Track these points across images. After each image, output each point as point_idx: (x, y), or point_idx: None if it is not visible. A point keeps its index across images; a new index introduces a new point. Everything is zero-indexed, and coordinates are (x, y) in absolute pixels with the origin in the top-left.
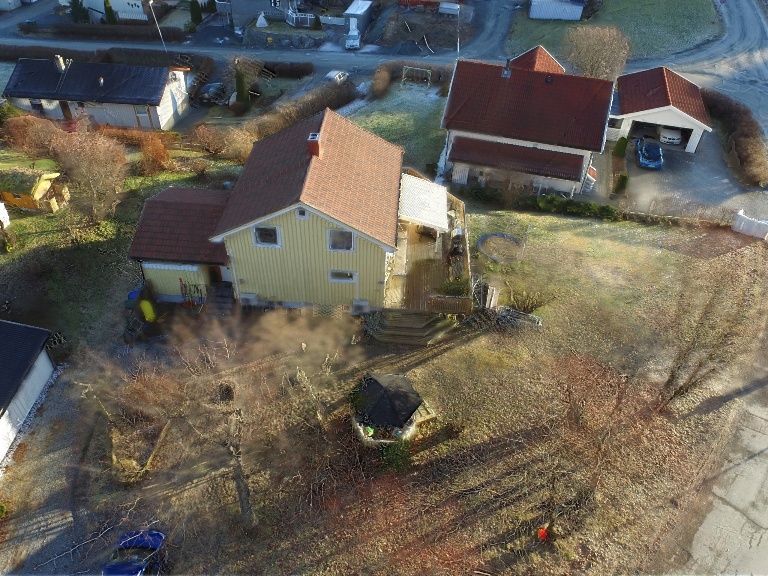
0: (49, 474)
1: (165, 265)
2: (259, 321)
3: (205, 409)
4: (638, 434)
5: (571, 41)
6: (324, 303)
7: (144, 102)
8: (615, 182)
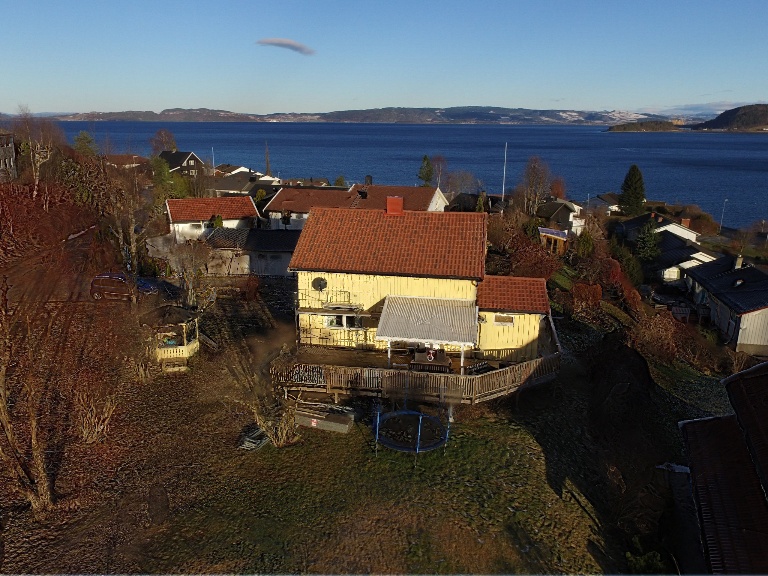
0: None
1: None
2: None
3: (237, 306)
4: None
5: None
6: None
7: (735, 307)
8: None
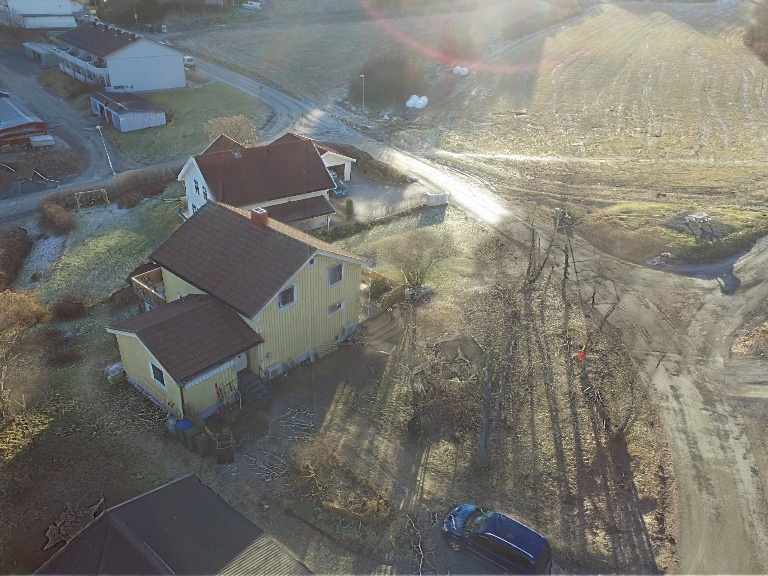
0: (327, 567)
1: (206, 375)
2: (291, 385)
3: (353, 447)
4: (542, 301)
5: (209, 133)
6: (324, 342)
7: None
8: (339, 210)
